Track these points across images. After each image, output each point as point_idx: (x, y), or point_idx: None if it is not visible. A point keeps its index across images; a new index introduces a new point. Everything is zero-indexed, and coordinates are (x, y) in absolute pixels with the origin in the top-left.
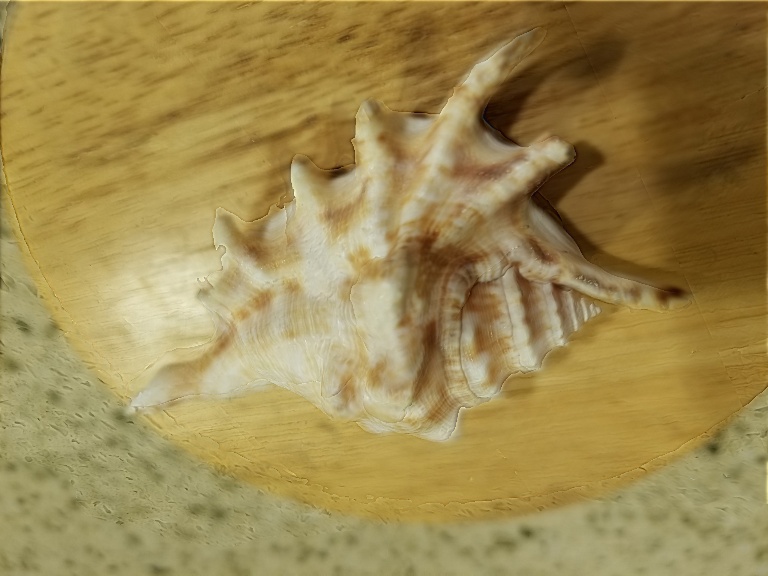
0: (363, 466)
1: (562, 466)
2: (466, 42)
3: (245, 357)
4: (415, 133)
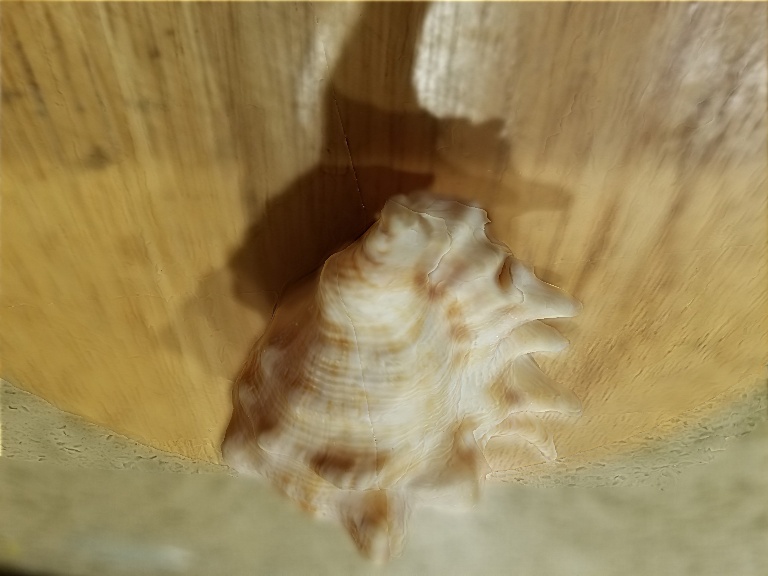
0: None
1: (6, 346)
2: None
3: (413, 351)
4: None
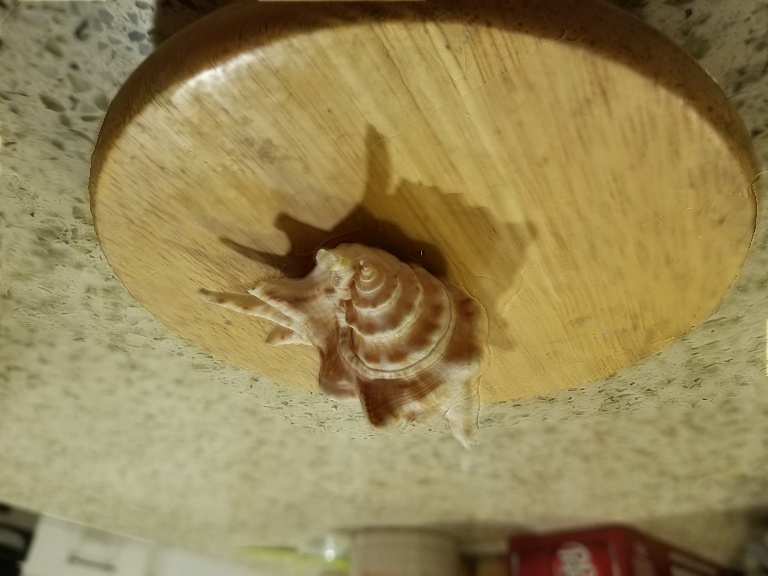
0: (664, 303)
1: (683, 173)
2: (242, 277)
3: None
4: None
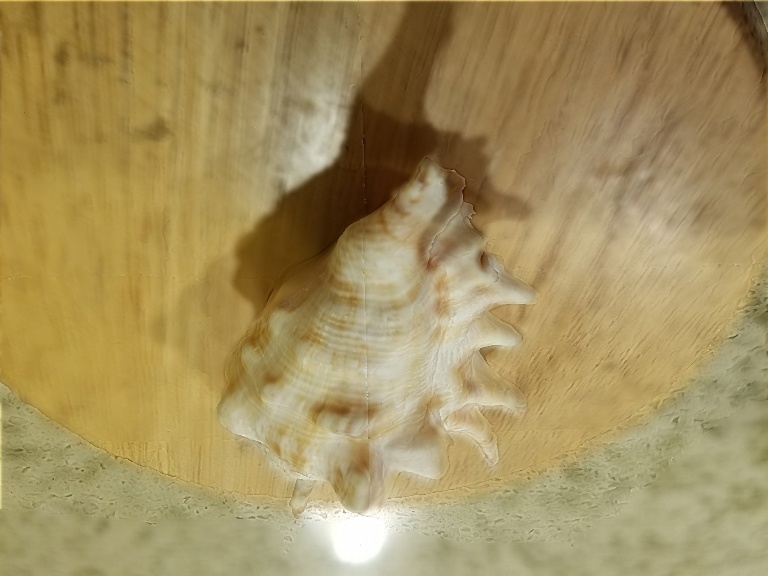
0: None
1: None
2: None
3: (411, 310)
4: None
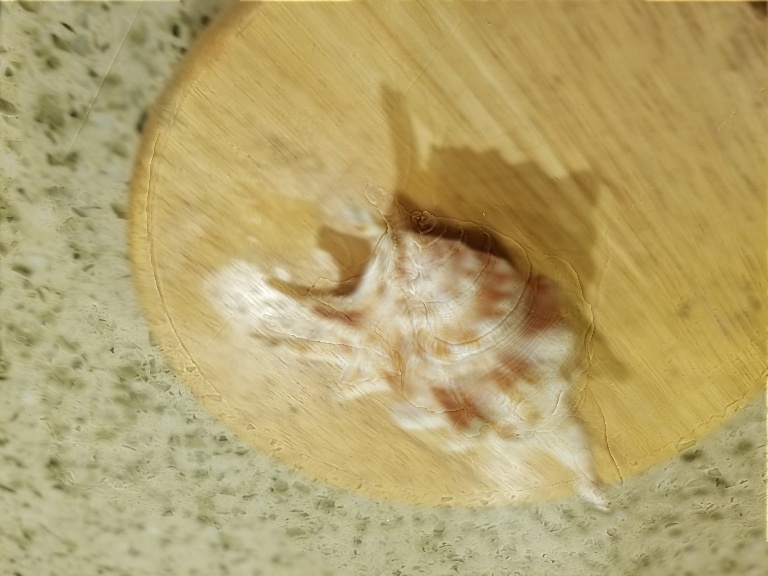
0: None
1: (736, 42)
2: (307, 315)
3: None
4: None
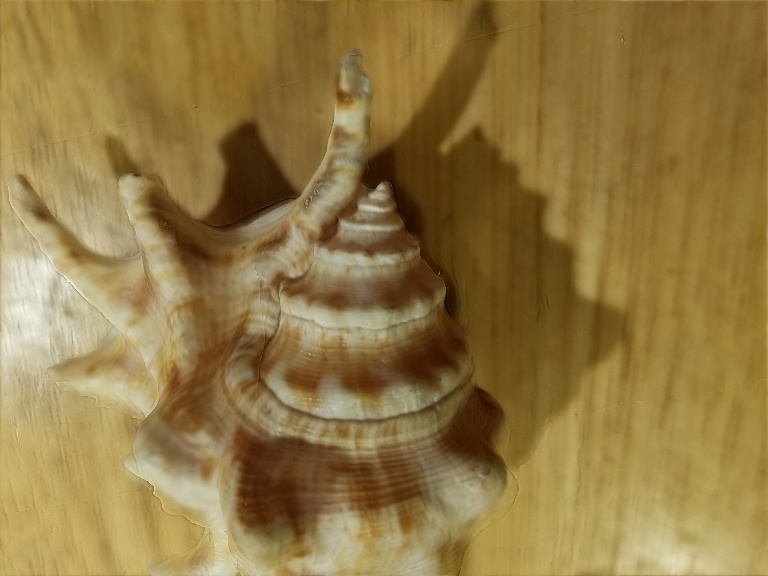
0: None
1: None
2: None
3: None
4: (117, 336)
